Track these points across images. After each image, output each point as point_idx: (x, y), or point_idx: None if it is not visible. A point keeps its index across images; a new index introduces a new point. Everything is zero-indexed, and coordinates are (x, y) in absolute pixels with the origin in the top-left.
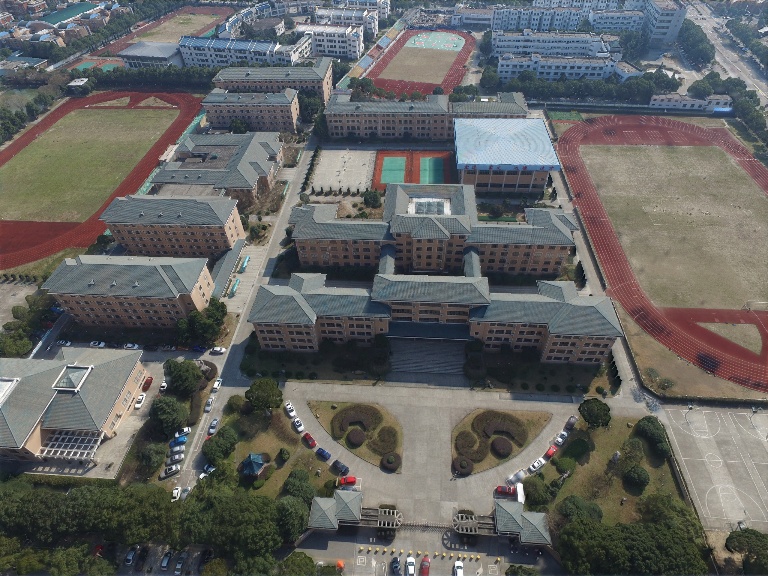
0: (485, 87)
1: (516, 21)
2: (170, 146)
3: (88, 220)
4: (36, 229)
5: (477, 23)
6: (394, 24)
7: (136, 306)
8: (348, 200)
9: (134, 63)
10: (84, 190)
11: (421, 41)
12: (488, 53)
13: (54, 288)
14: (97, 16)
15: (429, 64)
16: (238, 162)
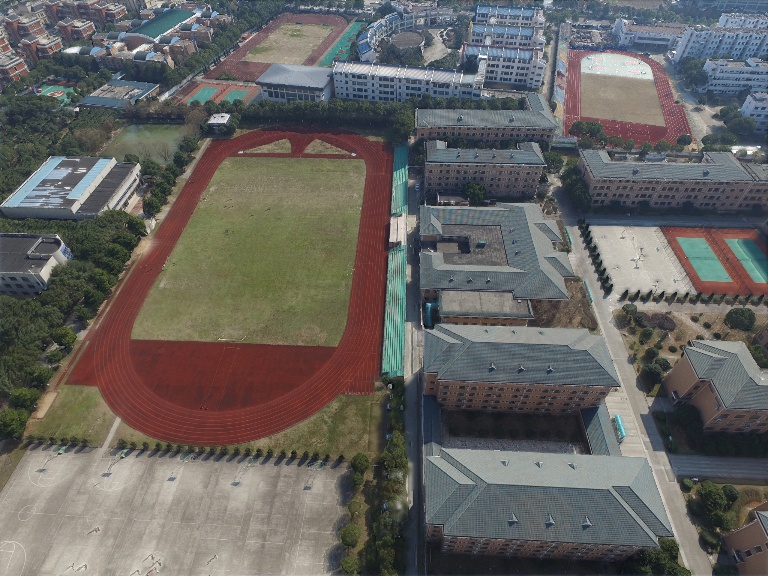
0: (724, 132)
1: (716, 45)
2: (391, 219)
3: (342, 342)
4: (277, 359)
5: (651, 43)
6: (559, 44)
7: (566, 545)
8: (679, 309)
9: (275, 92)
10: (309, 289)
11: (597, 65)
12: (702, 86)
13: (453, 527)
14: (198, 27)
15: (631, 98)
16: (534, 259)
